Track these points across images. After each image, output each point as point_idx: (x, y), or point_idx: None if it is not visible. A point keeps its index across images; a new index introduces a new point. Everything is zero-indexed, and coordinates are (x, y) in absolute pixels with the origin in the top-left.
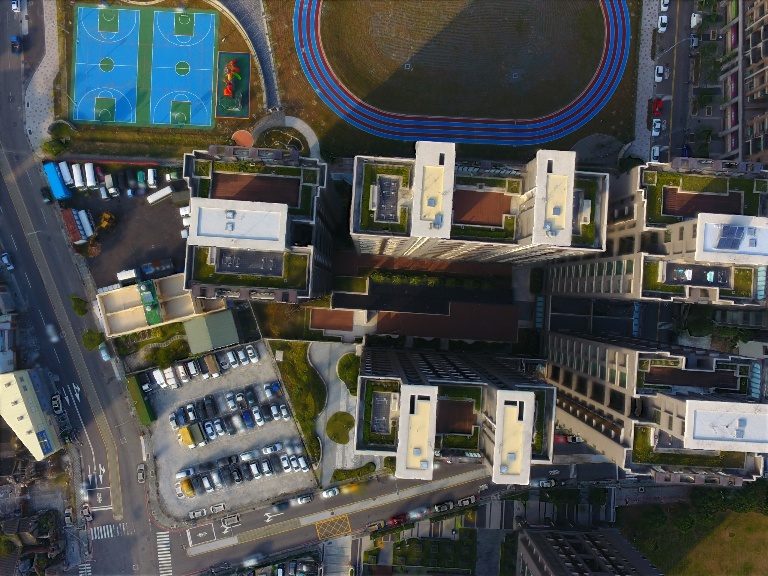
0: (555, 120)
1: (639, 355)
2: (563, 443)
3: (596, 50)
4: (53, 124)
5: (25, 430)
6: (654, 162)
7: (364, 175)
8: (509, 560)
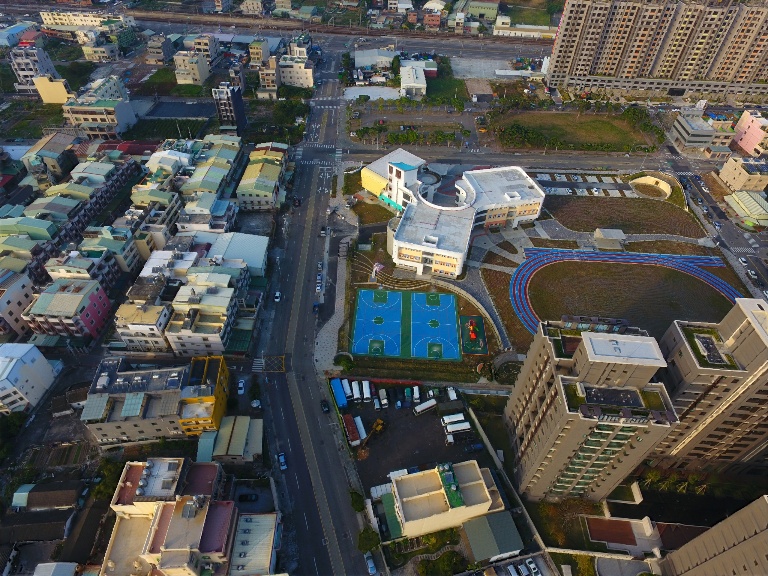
0: None
1: None
2: None
3: None
4: (338, 355)
5: None
6: None
7: (684, 334)
8: None
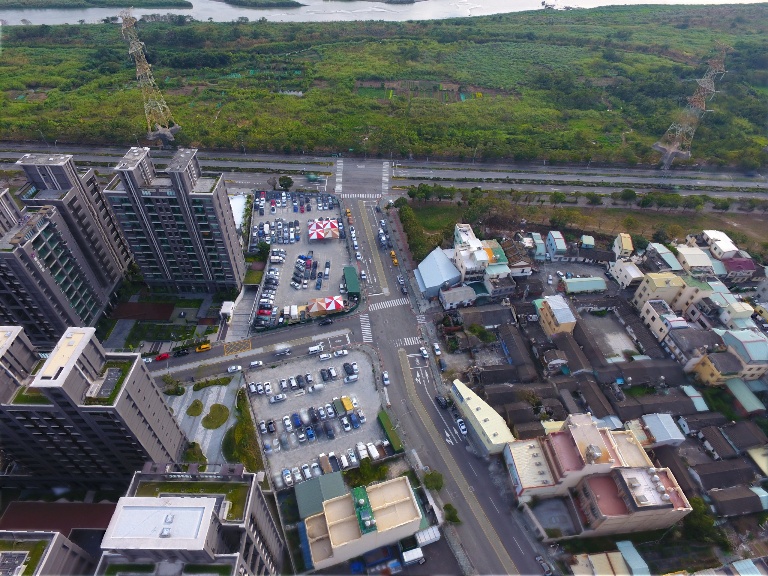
0: None
1: None
2: None
3: None
4: None
5: (473, 400)
6: None
7: None
8: (105, 329)
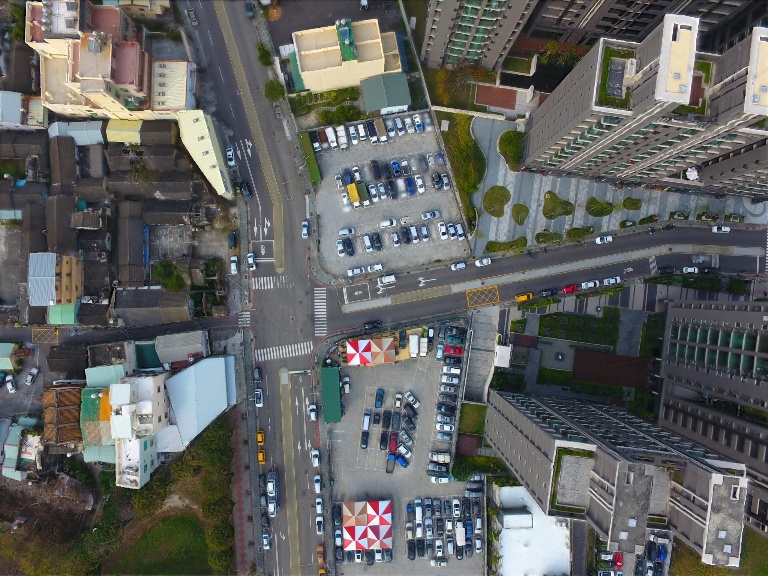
0: None
1: None
2: (707, 234)
3: None
4: None
5: (209, 164)
6: None
7: None
8: (650, 339)
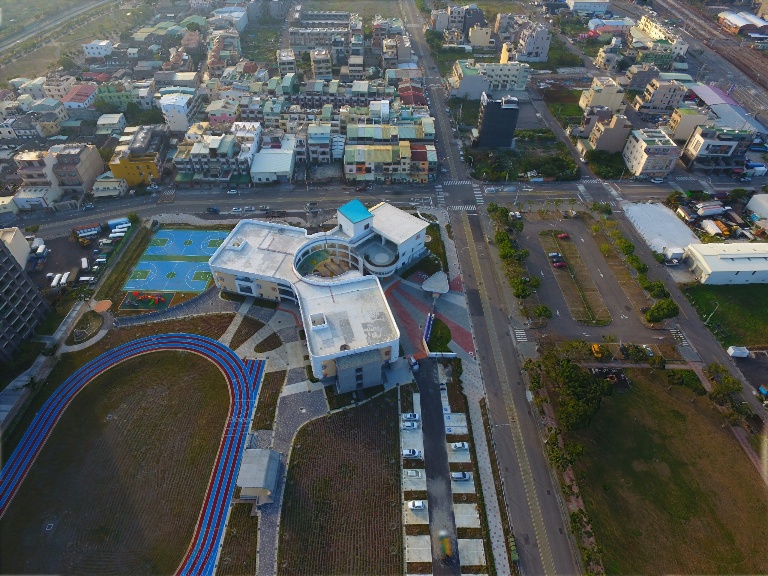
0: None
1: None
2: None
3: None
4: (158, 222)
5: None
6: None
7: None
8: None
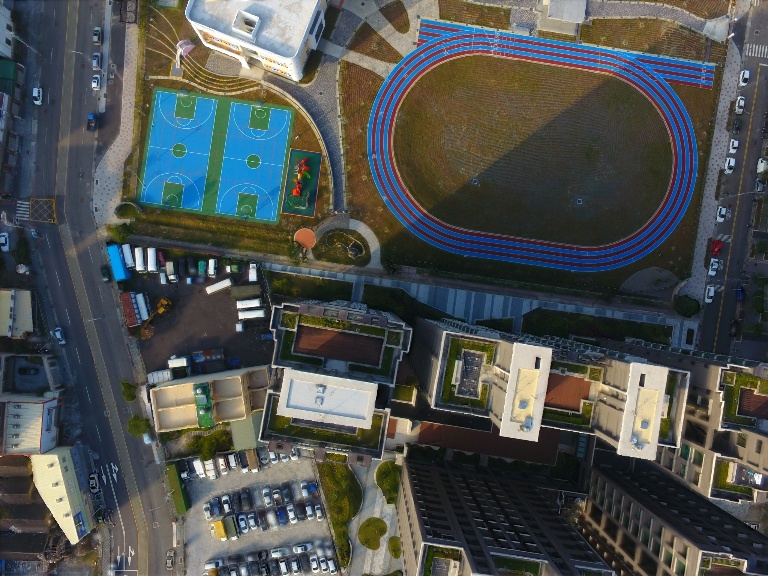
0: (615, 250)
1: (702, 554)
2: None
3: (662, 185)
4: (120, 205)
5: (63, 512)
6: (735, 365)
7: (450, 348)
8: None
